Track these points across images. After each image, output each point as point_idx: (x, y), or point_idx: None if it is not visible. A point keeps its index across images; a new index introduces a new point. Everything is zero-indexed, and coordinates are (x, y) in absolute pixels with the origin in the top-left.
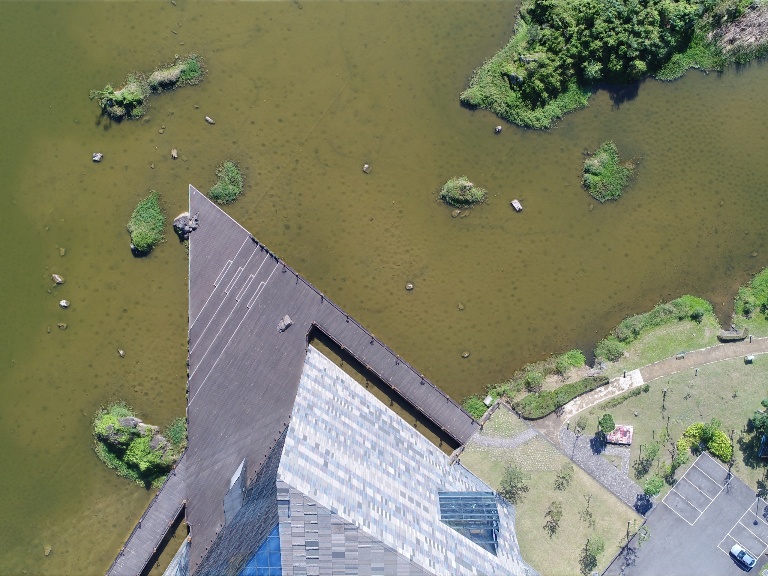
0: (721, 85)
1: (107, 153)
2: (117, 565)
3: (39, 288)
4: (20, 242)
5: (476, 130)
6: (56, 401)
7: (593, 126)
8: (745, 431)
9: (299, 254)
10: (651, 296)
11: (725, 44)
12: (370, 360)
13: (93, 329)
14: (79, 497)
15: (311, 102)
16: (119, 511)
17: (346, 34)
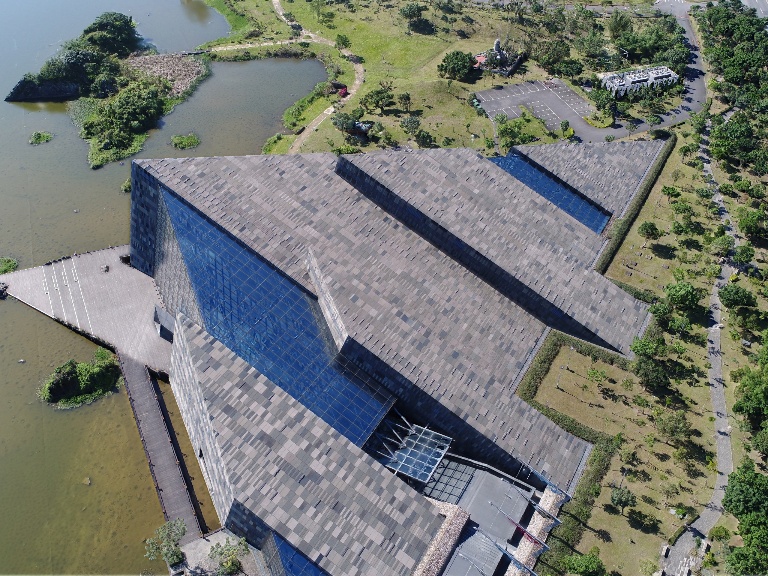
0: (192, 102)
1: None
2: (143, 429)
3: None
4: None
5: (112, 170)
6: (2, 416)
7: (160, 138)
8: (348, 142)
9: None
10: (256, 149)
11: (177, 94)
12: None
13: None
14: (76, 439)
15: (18, 217)
16: (112, 418)
17: (8, 192)
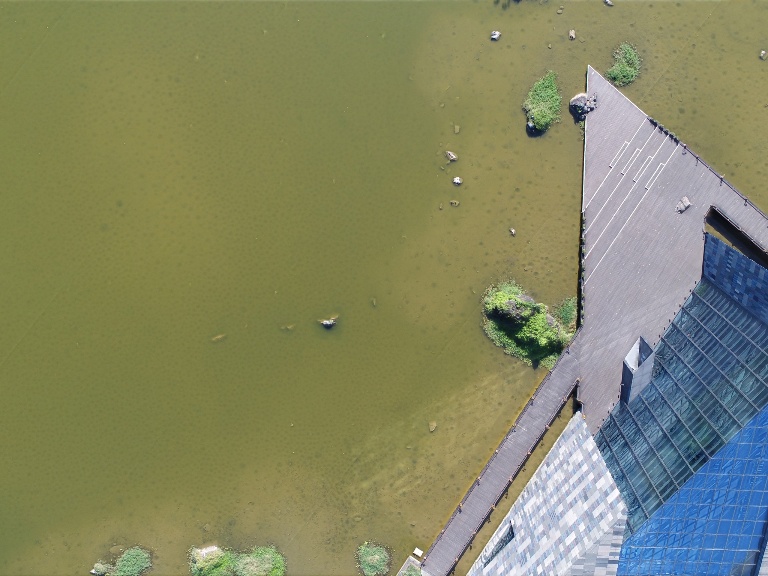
0: None
1: (504, 32)
2: (508, 441)
3: (432, 165)
4: (414, 118)
5: None
6: (446, 278)
7: None
8: None
9: (693, 138)
10: None
11: None
12: (767, 244)
13: (485, 207)
14: (465, 374)
15: None
16: (505, 389)
17: None
